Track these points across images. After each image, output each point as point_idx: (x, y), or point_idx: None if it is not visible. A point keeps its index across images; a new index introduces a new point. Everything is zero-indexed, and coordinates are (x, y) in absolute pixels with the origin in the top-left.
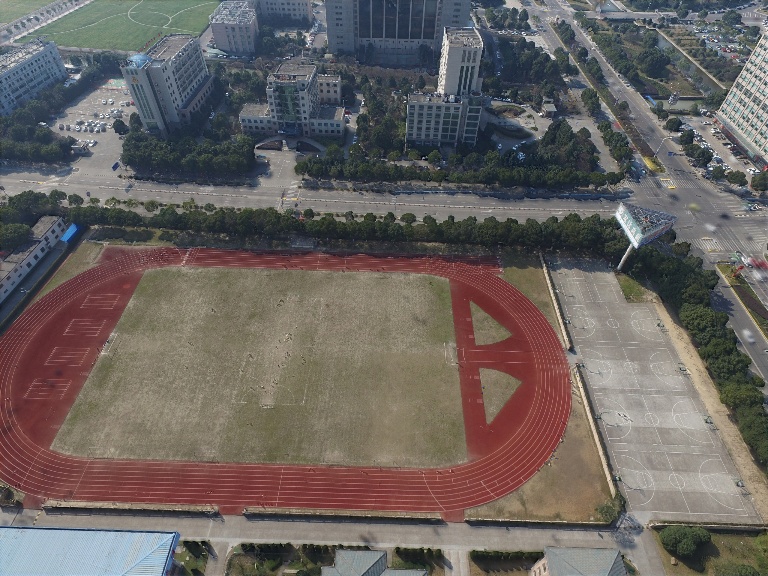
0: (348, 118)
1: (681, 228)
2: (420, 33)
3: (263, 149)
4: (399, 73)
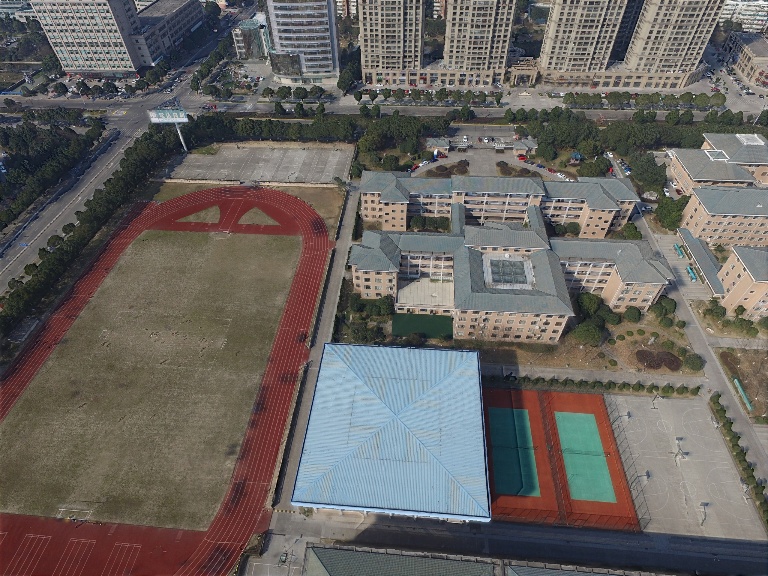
0: None
1: None
2: None
3: None
4: None
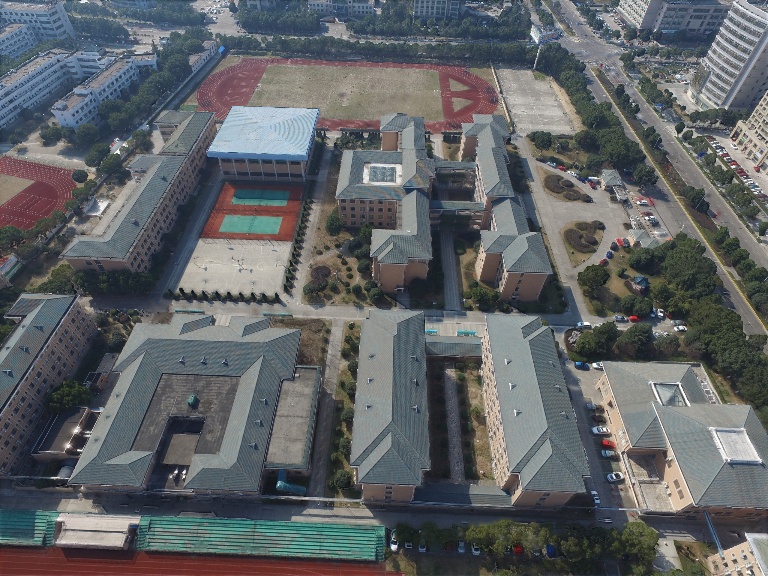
0: (375, 9)
1: (576, 56)
2: None
3: (323, 22)
4: None
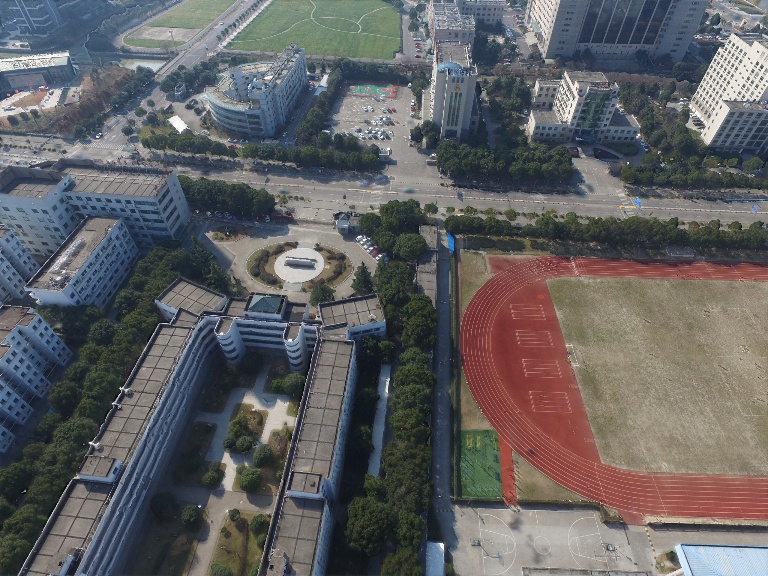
0: None
1: None
2: (641, 38)
3: None
4: (647, 79)
